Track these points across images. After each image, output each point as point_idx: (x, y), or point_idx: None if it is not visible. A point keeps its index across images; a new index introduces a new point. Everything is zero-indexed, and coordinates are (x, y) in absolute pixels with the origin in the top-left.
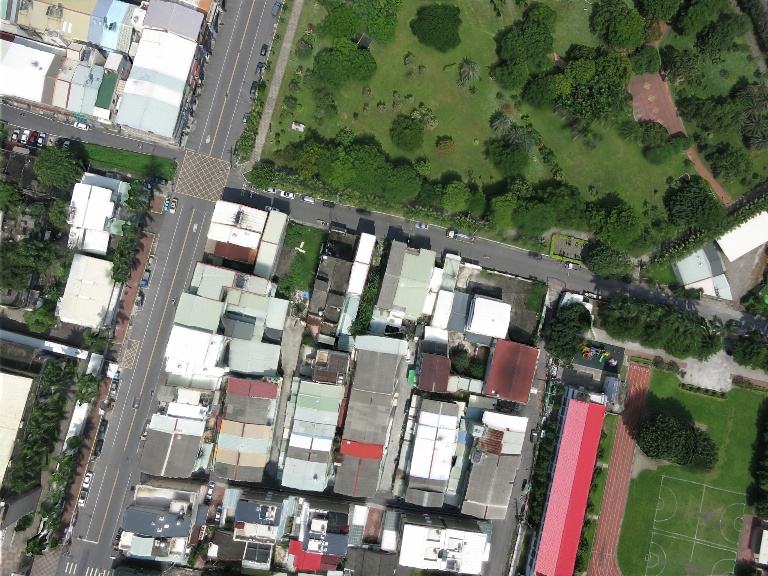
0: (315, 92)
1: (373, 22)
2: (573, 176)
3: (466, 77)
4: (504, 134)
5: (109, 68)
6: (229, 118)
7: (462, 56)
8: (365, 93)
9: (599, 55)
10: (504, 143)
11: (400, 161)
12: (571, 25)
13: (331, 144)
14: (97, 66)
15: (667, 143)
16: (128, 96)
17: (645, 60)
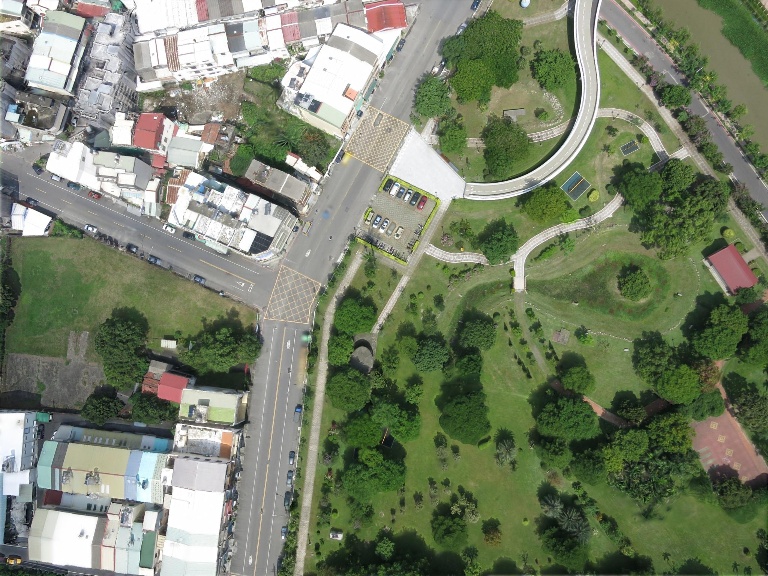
0: (347, 502)
1: (395, 429)
2: (643, 544)
3: (503, 459)
4: (555, 517)
5: (147, 529)
6: (267, 535)
7: (496, 427)
8: (399, 494)
9: (650, 417)
10: (557, 529)
11: (447, 555)
12: (612, 370)
13: (371, 564)
14: (136, 523)
15: (750, 500)
16: (167, 559)
17: (706, 406)
